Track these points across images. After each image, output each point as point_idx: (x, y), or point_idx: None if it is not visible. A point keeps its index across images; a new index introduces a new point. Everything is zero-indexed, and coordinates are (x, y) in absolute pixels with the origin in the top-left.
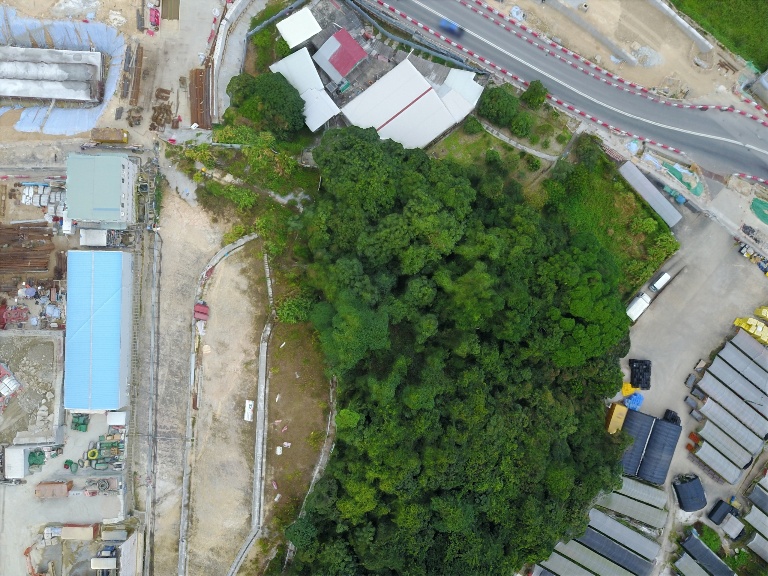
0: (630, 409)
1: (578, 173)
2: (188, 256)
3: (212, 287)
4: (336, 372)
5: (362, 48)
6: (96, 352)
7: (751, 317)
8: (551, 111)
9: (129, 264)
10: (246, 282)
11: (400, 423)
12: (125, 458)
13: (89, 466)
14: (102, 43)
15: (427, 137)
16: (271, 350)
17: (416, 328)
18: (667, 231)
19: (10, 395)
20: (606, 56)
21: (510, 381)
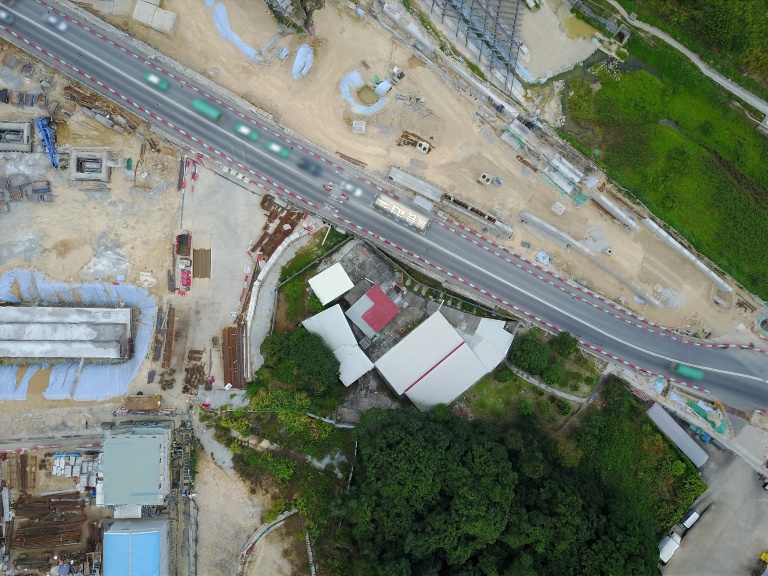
0: None
1: (609, 425)
2: (226, 529)
3: (252, 565)
4: None
5: (395, 304)
6: None
7: None
8: (579, 354)
9: (165, 535)
10: (289, 567)
11: None
12: None
13: None
14: (131, 299)
15: (460, 388)
16: None
17: None
18: (695, 473)
19: None
20: (630, 296)
21: None
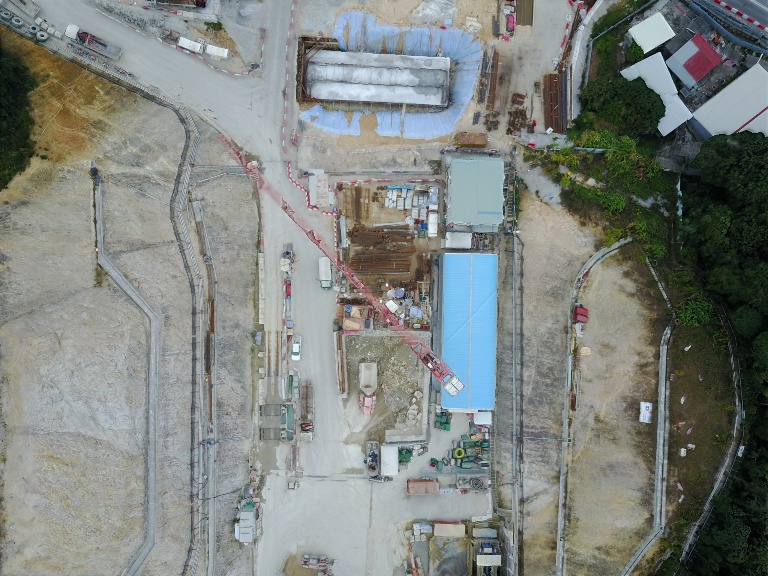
0: None
1: None
2: (557, 259)
3: (588, 290)
4: None
5: None
6: (474, 353)
7: None
8: None
9: None
10: (633, 285)
11: None
12: (489, 457)
13: (454, 464)
14: (451, 49)
15: None
16: (672, 353)
17: None
18: None
19: (453, 395)
20: None
21: None
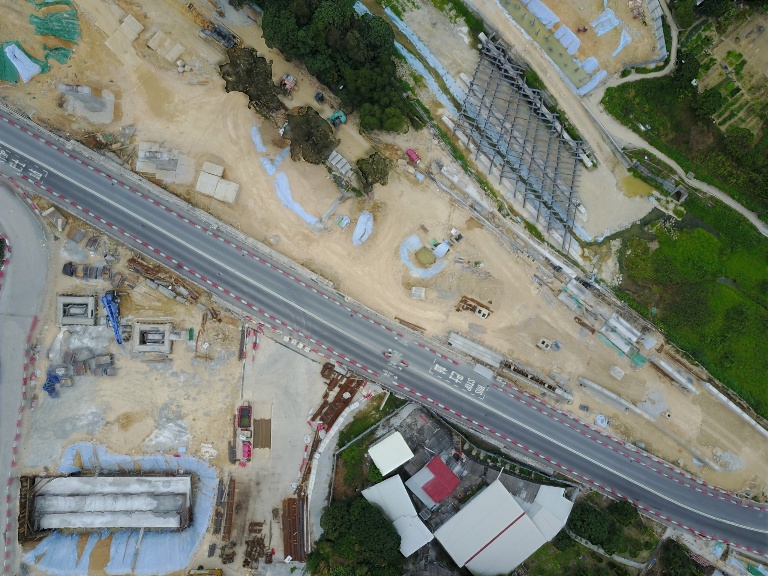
0: None
1: None
2: None
3: None
4: None
5: (455, 474)
6: None
7: None
8: (638, 519)
9: None
10: None
11: None
12: None
13: None
14: (191, 468)
15: (519, 558)
16: None
17: None
18: None
19: None
20: (688, 459)
21: None
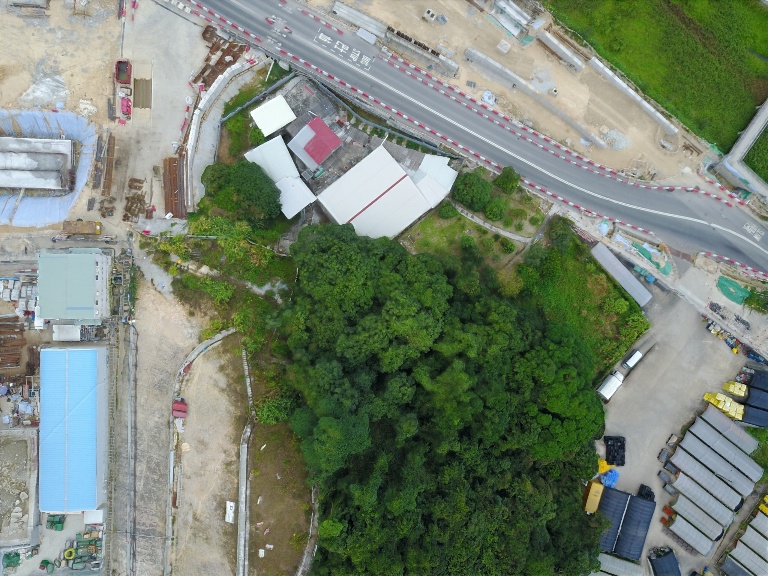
0: (606, 487)
1: (551, 258)
2: (165, 351)
3: (190, 383)
4: (318, 480)
5: (337, 136)
6: (71, 453)
7: (719, 392)
8: (524, 194)
9: (104, 358)
10: (225, 380)
11: (382, 524)
12: (103, 556)
13: (66, 566)
14: (72, 131)
15: (403, 223)
16: (251, 451)
17: (396, 428)
18: (638, 311)
19: None
20: (576, 139)
21: (489, 471)
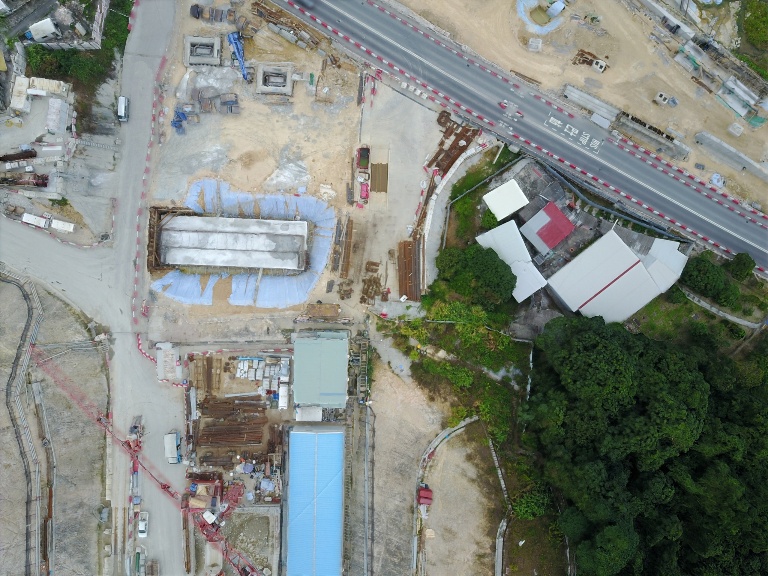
0: None
1: None
2: (406, 435)
3: (434, 469)
4: None
5: (570, 221)
6: (319, 534)
7: None
8: (753, 278)
9: None
10: (474, 470)
11: None
12: None
13: None
14: (308, 213)
15: (633, 308)
16: (508, 546)
17: (660, 530)
18: None
19: None
20: None
21: (740, 572)
